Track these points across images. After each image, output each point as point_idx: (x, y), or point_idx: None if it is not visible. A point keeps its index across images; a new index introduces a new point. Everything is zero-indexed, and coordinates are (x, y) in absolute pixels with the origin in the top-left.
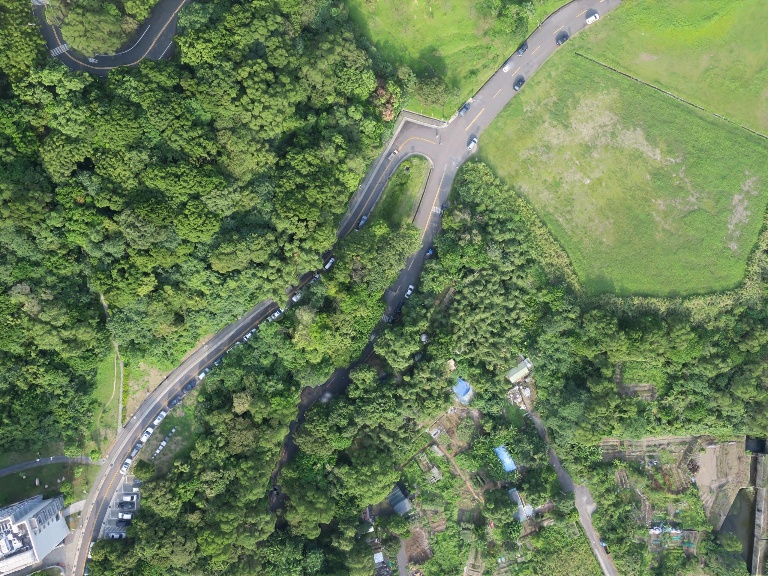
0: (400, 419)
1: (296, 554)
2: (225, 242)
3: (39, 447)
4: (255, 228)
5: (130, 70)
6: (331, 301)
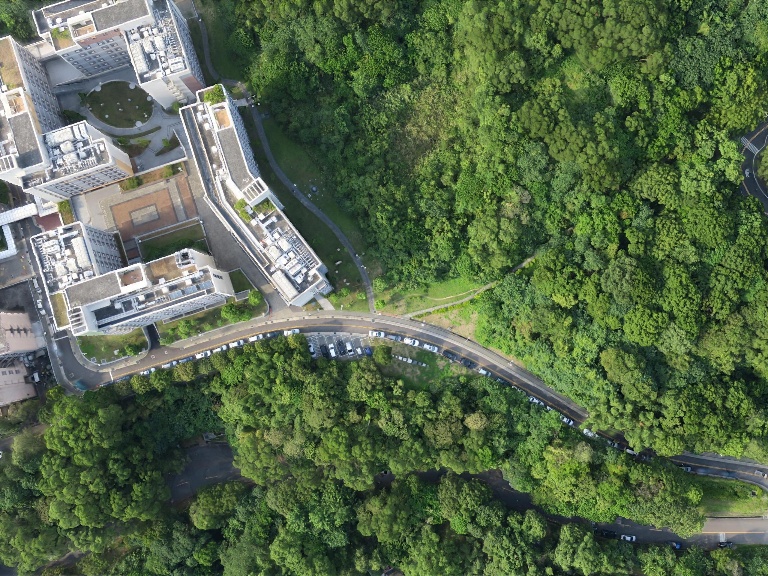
0: (501, 575)
1: (341, 520)
2: (635, 357)
3: (374, 255)
4: (654, 377)
5: (763, 214)
6: (599, 468)
